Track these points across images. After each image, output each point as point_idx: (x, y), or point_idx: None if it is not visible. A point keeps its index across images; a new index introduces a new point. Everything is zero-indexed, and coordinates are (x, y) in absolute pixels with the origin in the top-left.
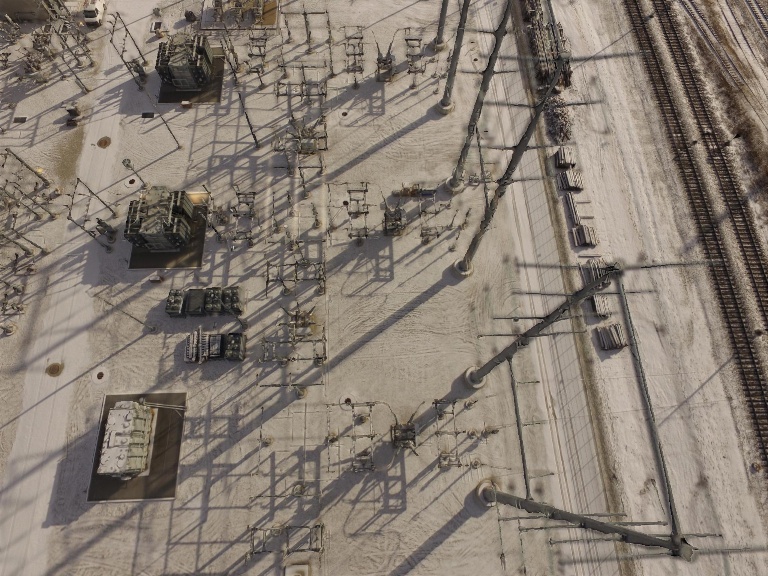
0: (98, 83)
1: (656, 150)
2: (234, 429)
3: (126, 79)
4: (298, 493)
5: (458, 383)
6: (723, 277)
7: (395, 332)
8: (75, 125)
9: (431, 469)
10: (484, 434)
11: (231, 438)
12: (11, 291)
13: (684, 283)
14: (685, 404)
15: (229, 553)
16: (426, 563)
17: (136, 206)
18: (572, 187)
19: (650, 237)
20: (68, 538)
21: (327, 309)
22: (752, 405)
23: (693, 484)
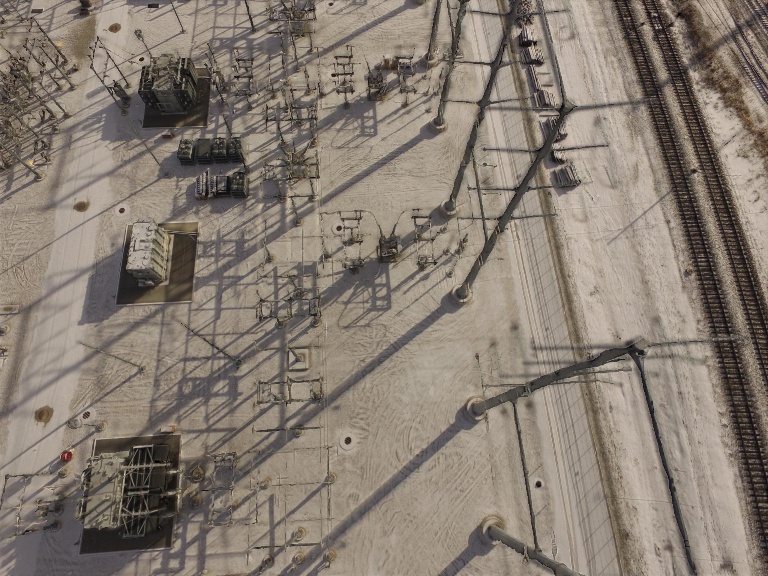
0: None
1: (608, 31)
2: (241, 250)
3: None
4: (298, 296)
5: (435, 214)
6: (665, 129)
7: (379, 175)
8: (88, 14)
9: (412, 278)
10: (457, 251)
11: (239, 257)
12: (39, 147)
13: (631, 135)
14: (630, 227)
15: (240, 342)
16: (409, 347)
17: (148, 69)
18: (534, 60)
19: (602, 100)
20: (101, 332)
21: (319, 158)
22: (687, 226)
23: (636, 287)
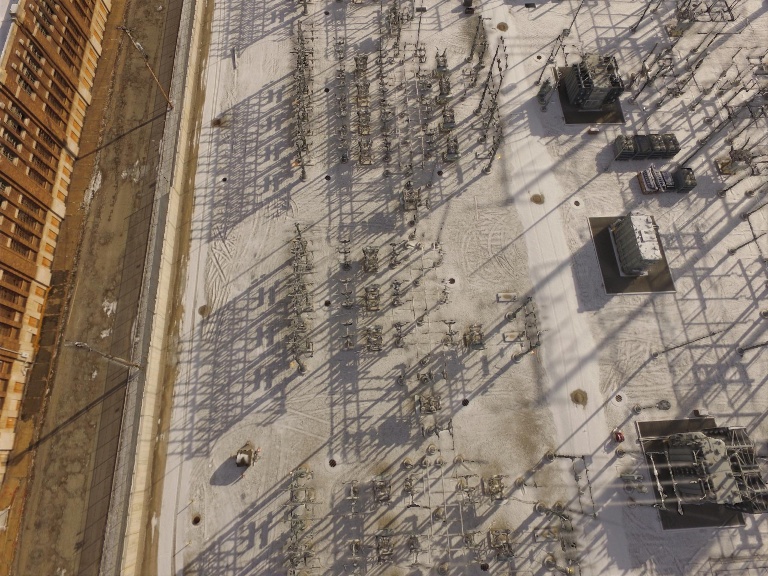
0: None
1: None
2: (701, 243)
3: None
4: None
5: None
6: None
7: None
8: (473, 13)
9: None
10: None
11: (701, 249)
12: (475, 141)
13: None
14: None
15: (734, 330)
16: None
17: (581, 67)
18: None
19: None
20: (602, 320)
21: None
22: None
23: None
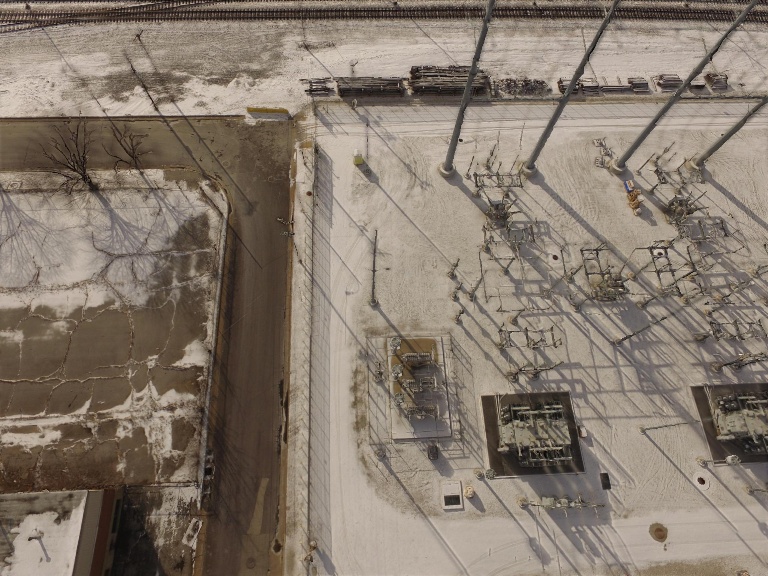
0: (566, 569)
1: (544, 29)
2: None
3: (553, 527)
4: None
5: None
6: (649, 14)
7: (766, 217)
8: None
9: None
10: None
11: None
12: None
13: (659, 35)
14: (746, 52)
15: None
16: None
17: None
18: (598, 85)
19: (627, 47)
20: None
21: None
22: None
23: None
